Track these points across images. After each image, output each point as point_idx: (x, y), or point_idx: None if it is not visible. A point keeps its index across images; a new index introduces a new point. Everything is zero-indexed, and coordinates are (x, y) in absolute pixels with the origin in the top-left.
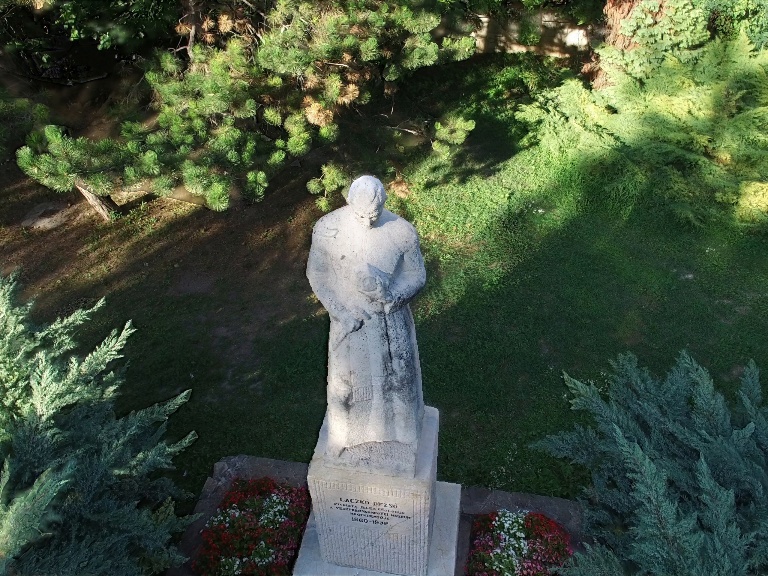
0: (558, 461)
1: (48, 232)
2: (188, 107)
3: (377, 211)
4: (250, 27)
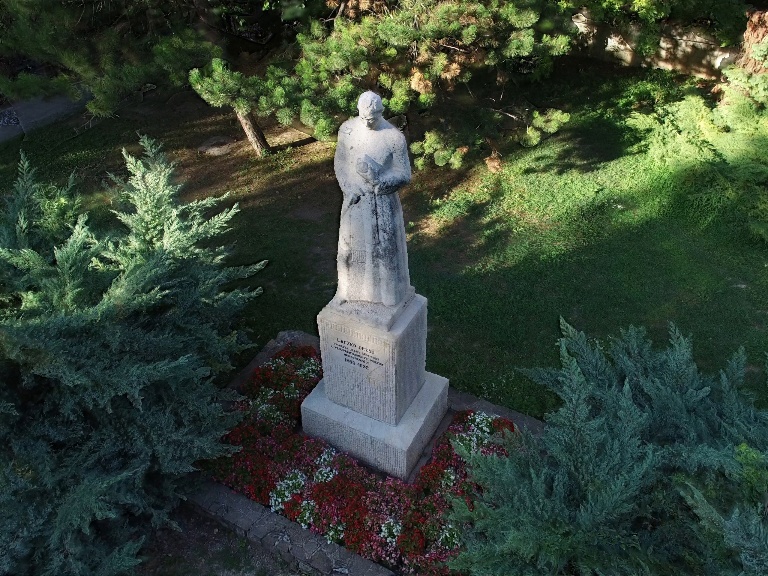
0: (546, 394)
1: (215, 157)
2: (321, 63)
3: (372, 115)
4: (386, 8)
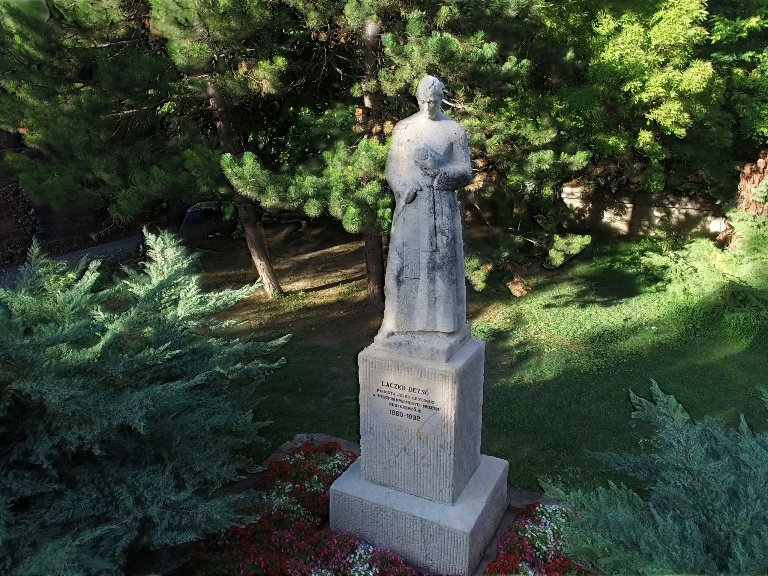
0: None
1: None
2: (347, 173)
3: (433, 96)
4: None
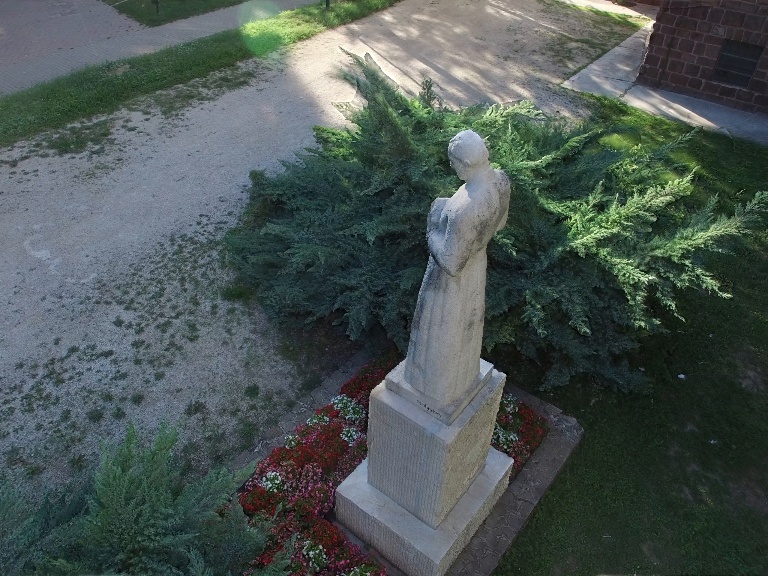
0: None
1: None
2: None
3: None
4: None
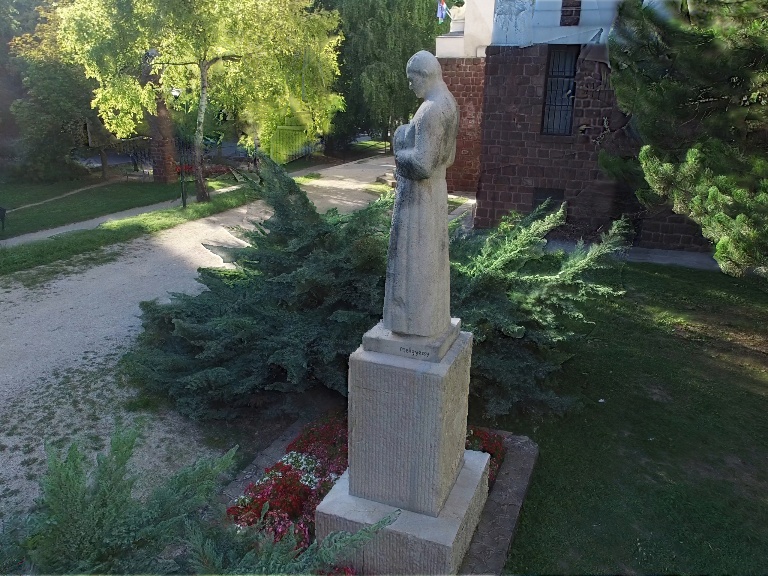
0: None
1: None
2: None
3: None
4: None
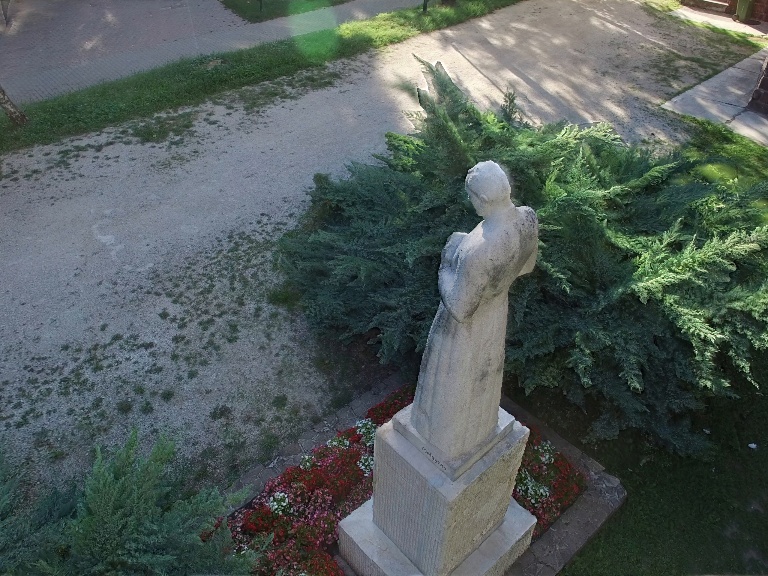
0: None
1: None
2: None
3: None
4: None
